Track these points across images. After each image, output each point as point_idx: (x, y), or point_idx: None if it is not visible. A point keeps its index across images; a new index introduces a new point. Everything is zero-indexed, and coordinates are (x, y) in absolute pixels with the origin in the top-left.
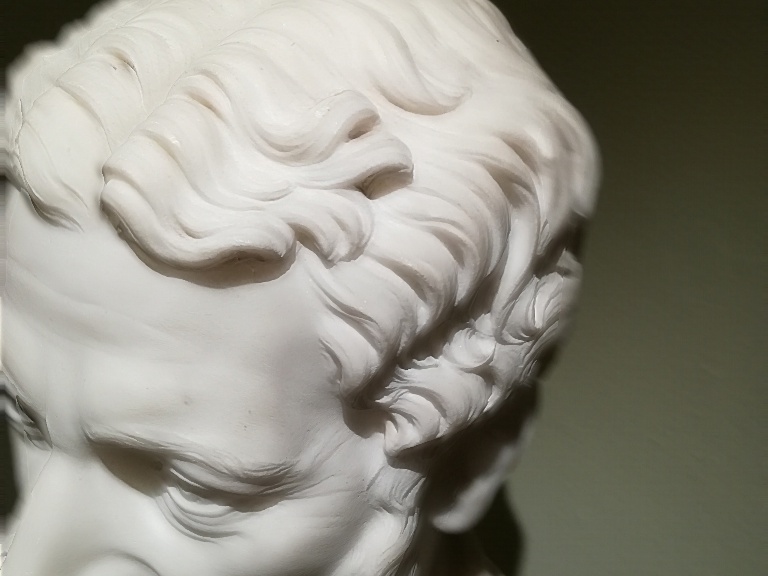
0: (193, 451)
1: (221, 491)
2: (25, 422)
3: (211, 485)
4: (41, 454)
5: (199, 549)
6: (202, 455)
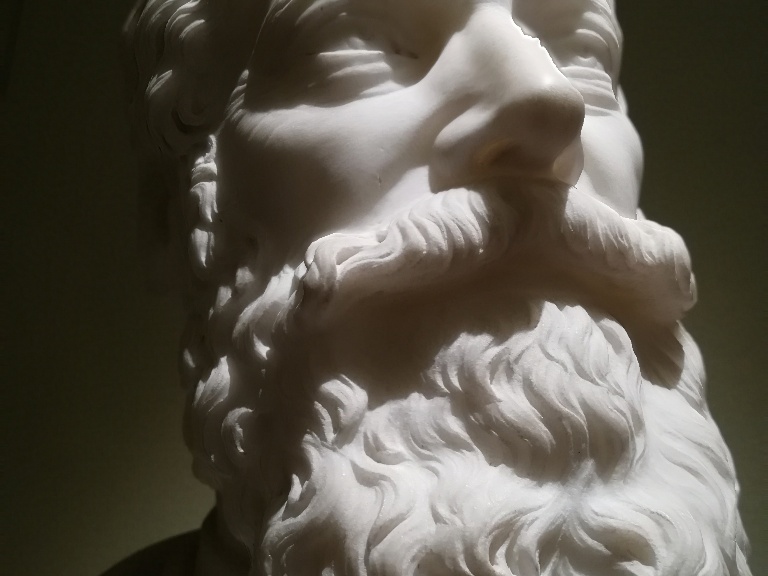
0: (599, 1)
1: (610, 54)
2: (368, 57)
3: (612, 37)
4: (386, 97)
5: (602, 123)
6: (604, 6)
